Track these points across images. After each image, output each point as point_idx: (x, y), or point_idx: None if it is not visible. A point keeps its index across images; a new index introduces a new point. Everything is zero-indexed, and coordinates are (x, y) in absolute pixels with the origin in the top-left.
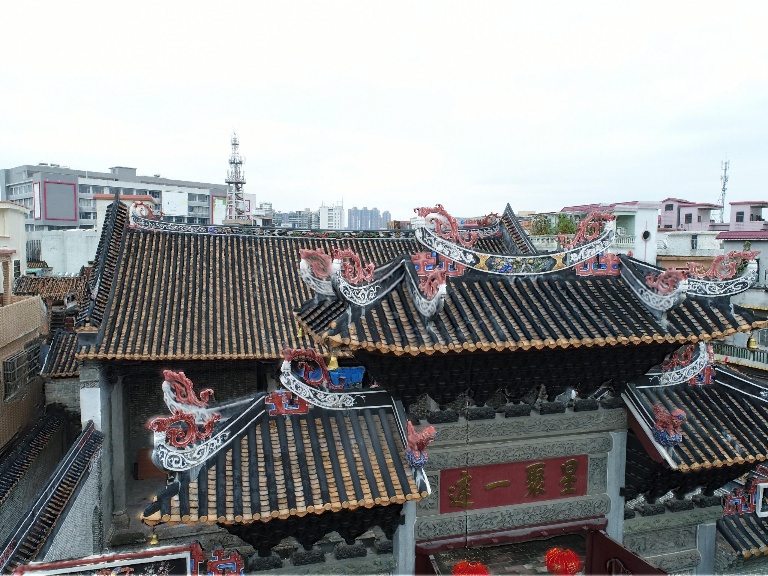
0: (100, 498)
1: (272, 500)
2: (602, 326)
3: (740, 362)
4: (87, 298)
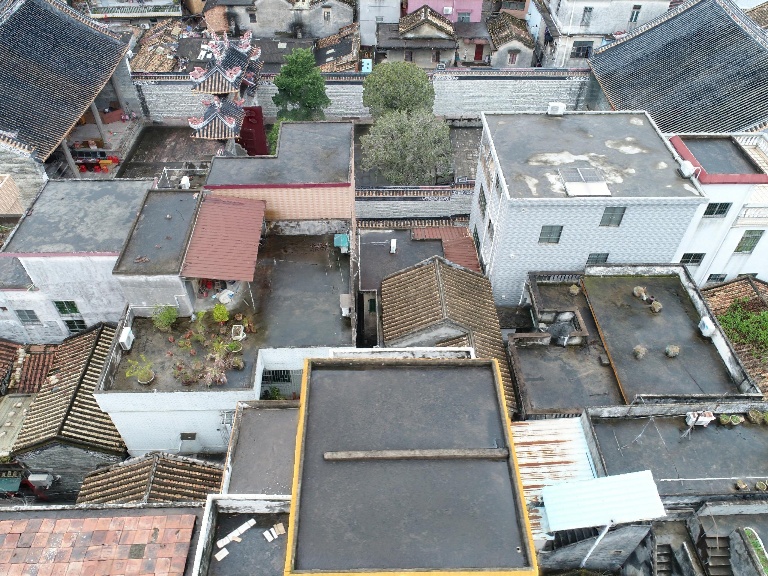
0: None
1: (238, 125)
2: (243, 62)
3: (114, 16)
4: (4, 139)
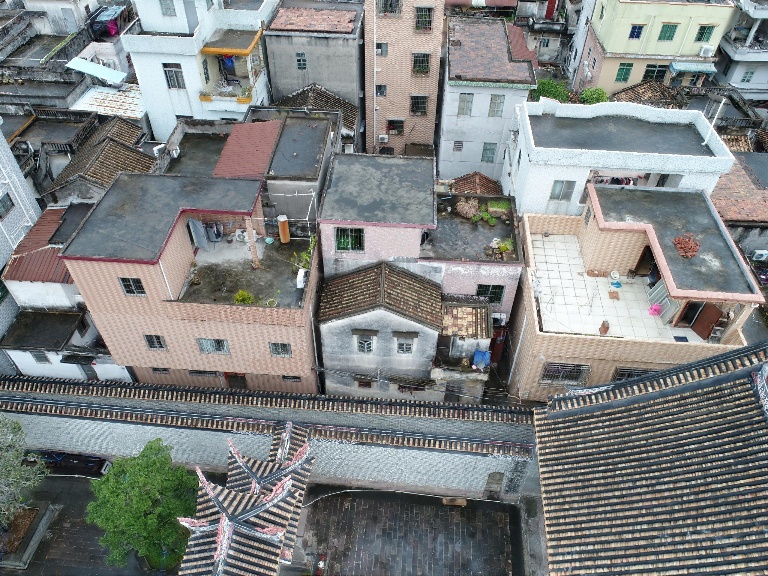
0: (516, 474)
1: None
2: None
3: None
4: None
